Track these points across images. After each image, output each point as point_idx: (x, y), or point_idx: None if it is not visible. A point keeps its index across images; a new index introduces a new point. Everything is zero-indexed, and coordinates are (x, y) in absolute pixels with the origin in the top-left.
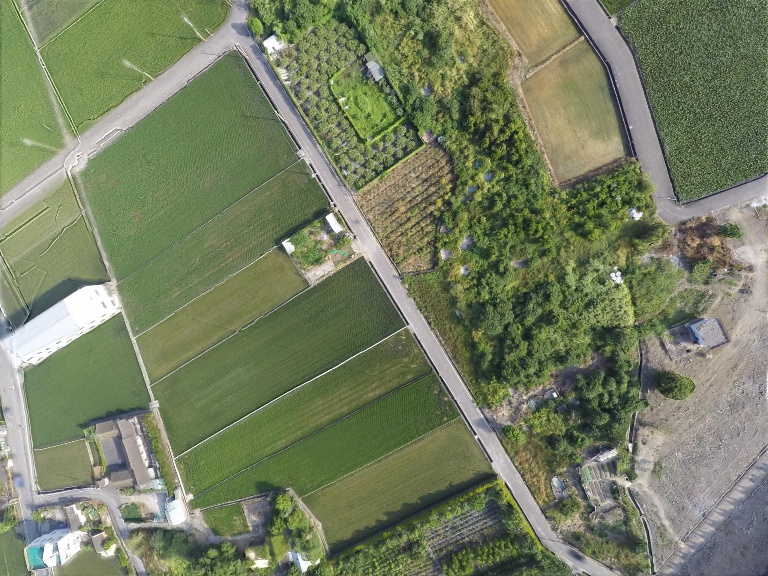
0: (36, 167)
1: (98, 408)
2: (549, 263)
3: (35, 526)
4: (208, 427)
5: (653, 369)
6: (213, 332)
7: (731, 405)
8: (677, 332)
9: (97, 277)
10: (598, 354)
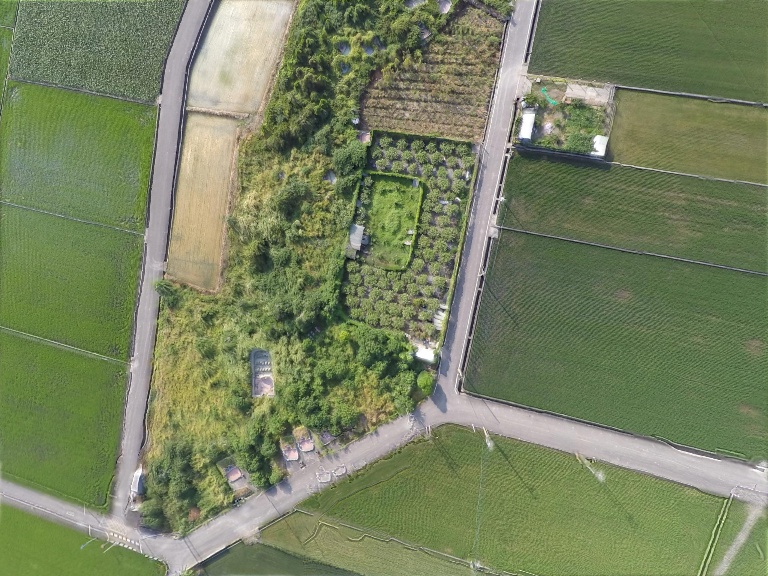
0: None
1: None
2: None
3: None
4: None
5: None
6: None
7: None
8: None
9: None
10: None
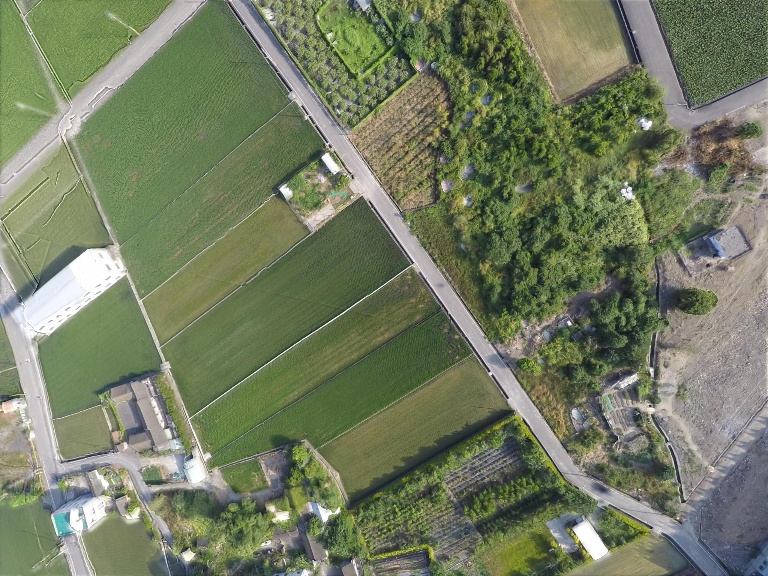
0: (32, 138)
1: (111, 374)
2: (555, 185)
3: (61, 494)
4: (220, 385)
5: (672, 287)
6: (218, 288)
7: (757, 319)
8: (695, 246)
9: (100, 242)
10: (612, 277)
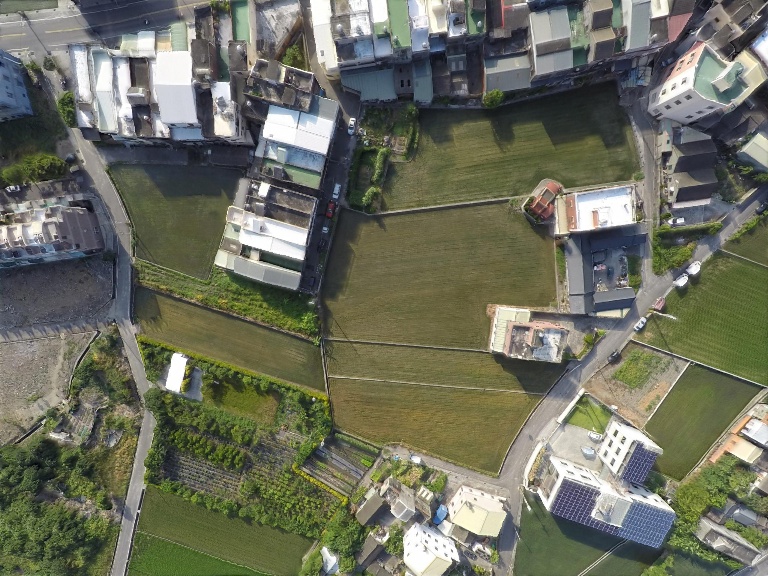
0: None
1: None
2: (1, 559)
3: None
4: None
5: None
6: None
7: None
8: None
9: None
10: None
